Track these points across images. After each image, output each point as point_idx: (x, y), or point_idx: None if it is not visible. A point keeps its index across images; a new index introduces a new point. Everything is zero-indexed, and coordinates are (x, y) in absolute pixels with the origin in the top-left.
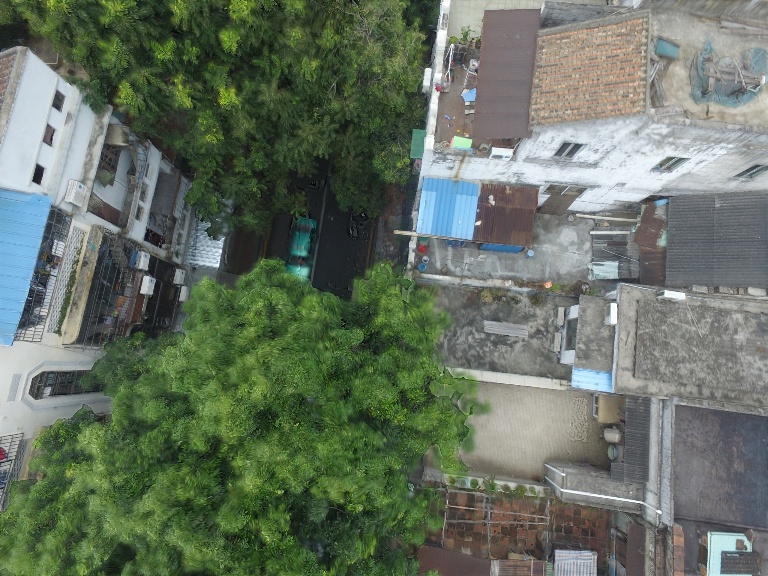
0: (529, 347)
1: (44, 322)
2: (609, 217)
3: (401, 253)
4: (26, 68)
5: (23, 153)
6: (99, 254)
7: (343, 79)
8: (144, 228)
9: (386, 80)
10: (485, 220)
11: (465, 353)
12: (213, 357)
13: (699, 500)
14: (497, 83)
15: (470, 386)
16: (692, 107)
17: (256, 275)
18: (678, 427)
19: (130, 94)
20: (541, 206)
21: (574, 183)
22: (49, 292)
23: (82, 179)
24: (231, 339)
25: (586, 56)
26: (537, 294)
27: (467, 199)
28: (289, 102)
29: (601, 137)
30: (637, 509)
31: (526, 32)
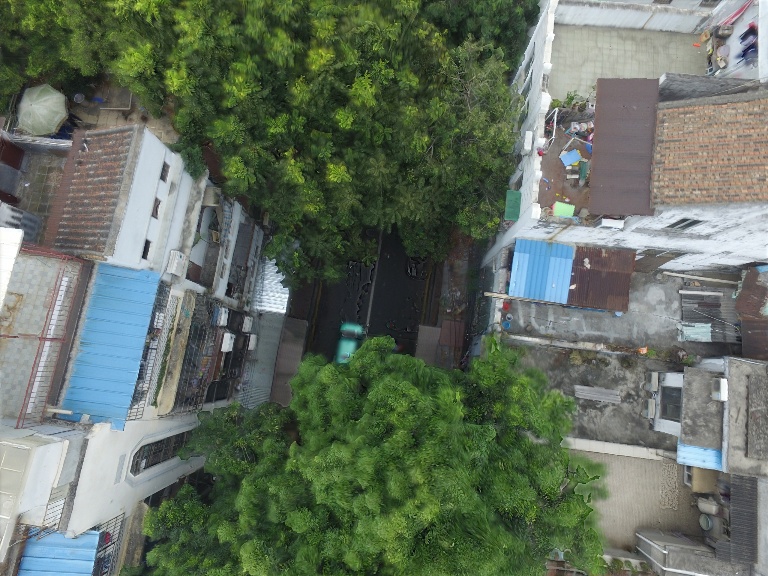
0: (619, 412)
1: (145, 397)
2: (700, 277)
3: (470, 300)
4: (143, 146)
5: (136, 231)
6: None
7: (438, 139)
8: (226, 284)
9: (484, 142)
10: (580, 284)
11: (553, 417)
12: (365, 472)
13: None
14: (614, 156)
15: None
16: None
17: (372, 358)
18: None
19: (241, 168)
20: None
21: (676, 249)
22: (150, 366)
23: (180, 247)
24: (379, 450)
25: (714, 133)
26: (627, 356)
27: (561, 262)
28: None
29: (727, 217)
30: None
31: (644, 103)
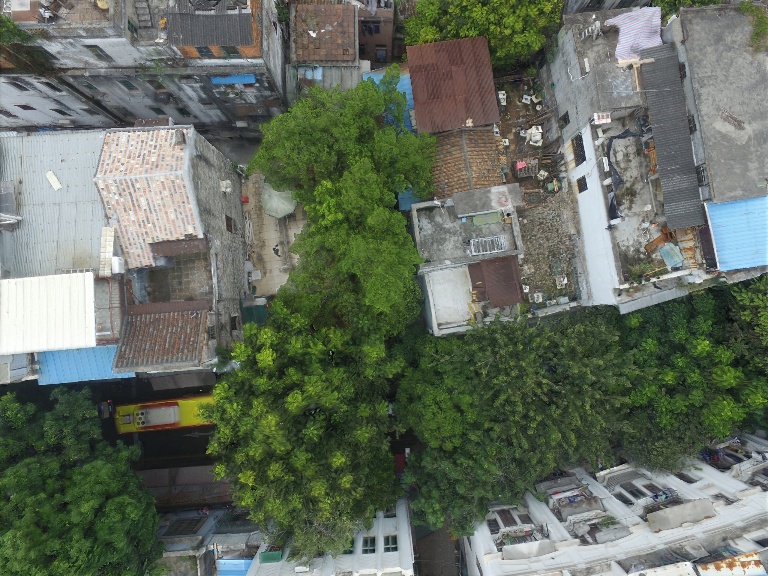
0: None
1: None
2: None
3: None
4: None
5: None
6: None
7: None
8: None
9: None
10: None
11: None
12: (11, 567)
13: None
14: None
15: None
16: None
17: (112, 518)
18: None
19: None
20: None
21: None
22: None
23: None
24: (28, 567)
25: None
26: None
27: None
28: None
29: None
30: None
31: None
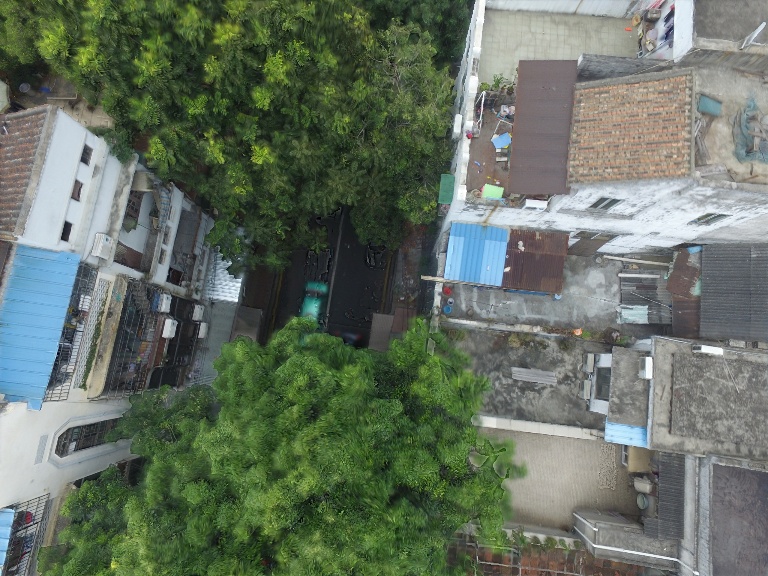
0: (557, 393)
1: (70, 379)
2: (638, 260)
3: (422, 288)
4: (56, 127)
5: (52, 212)
6: (123, 302)
7: (371, 124)
8: (166, 271)
9: (415, 126)
10: (514, 266)
11: (492, 399)
12: (255, 442)
13: (737, 561)
14: (533, 136)
15: (496, 432)
16: (735, 166)
17: (289, 337)
18: (715, 485)
19: (160, 149)
20: (569, 248)
21: (606, 231)
22: (75, 348)
23: (108, 230)
24: (273, 421)
25: (626, 112)
26: (565, 339)
27: (496, 245)
28: (317, 149)
29: (641, 195)
30: (671, 566)
31: (563, 84)
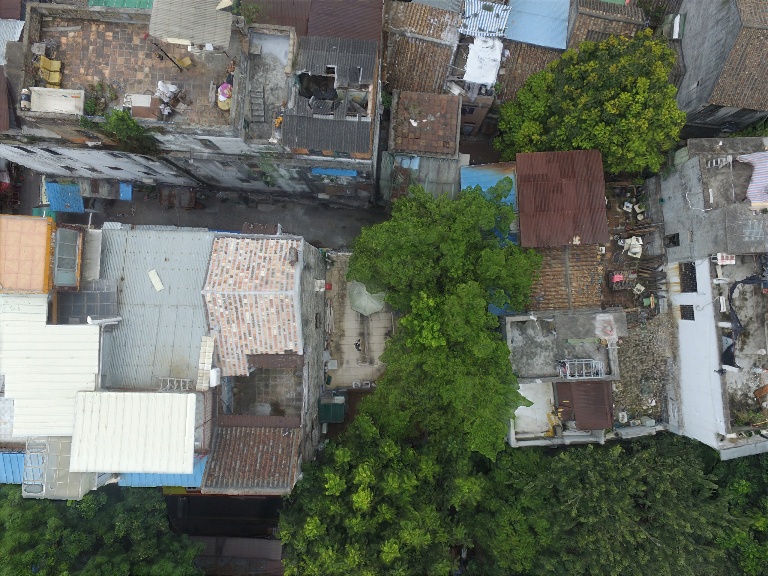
0: None
1: None
2: None
3: None
4: None
5: None
6: None
7: None
8: None
9: None
10: None
11: None
12: None
13: None
14: None
15: None
16: None
17: None
18: None
19: None
20: None
21: None
22: None
23: None
24: None
25: None
26: None
27: None
28: None
29: None
30: None
31: None
